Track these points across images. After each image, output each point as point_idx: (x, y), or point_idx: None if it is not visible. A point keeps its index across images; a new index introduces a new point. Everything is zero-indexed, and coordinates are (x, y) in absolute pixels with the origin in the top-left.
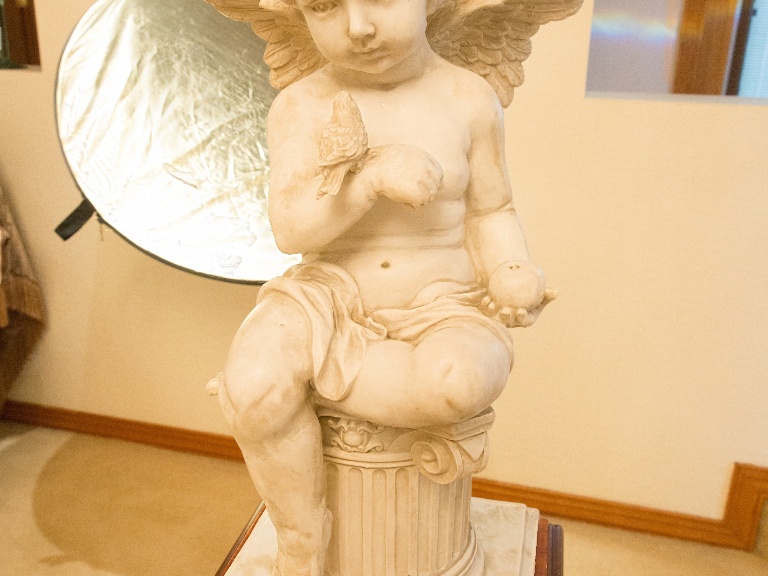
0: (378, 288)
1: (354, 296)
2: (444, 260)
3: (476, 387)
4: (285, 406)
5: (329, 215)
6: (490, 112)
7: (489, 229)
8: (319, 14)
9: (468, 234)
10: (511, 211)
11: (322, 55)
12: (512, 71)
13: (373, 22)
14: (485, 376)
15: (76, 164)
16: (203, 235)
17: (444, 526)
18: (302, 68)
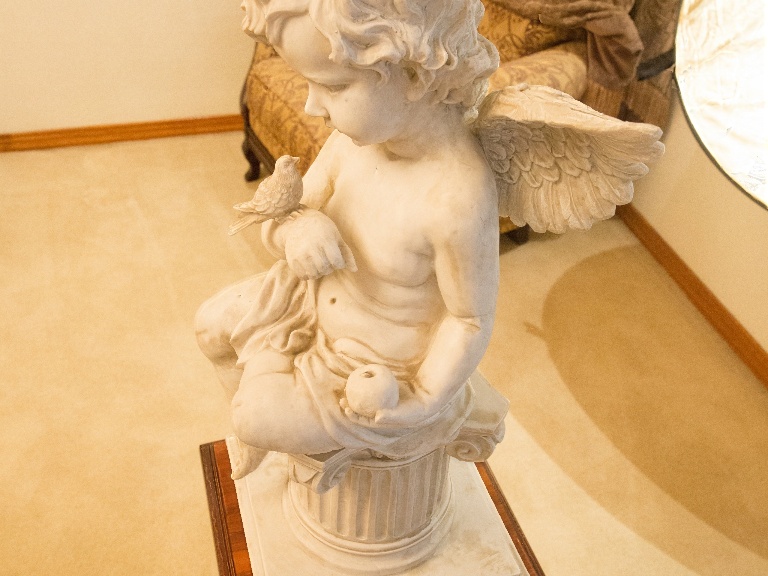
0: (322, 314)
1: (312, 307)
2: (369, 328)
3: (244, 430)
4: (211, 347)
5: (267, 242)
6: (446, 228)
7: (442, 328)
8: None
9: (442, 319)
10: (472, 326)
11: None
12: (607, 185)
13: (325, 107)
14: (256, 429)
15: (688, 8)
16: (761, 132)
17: (347, 510)
18: None
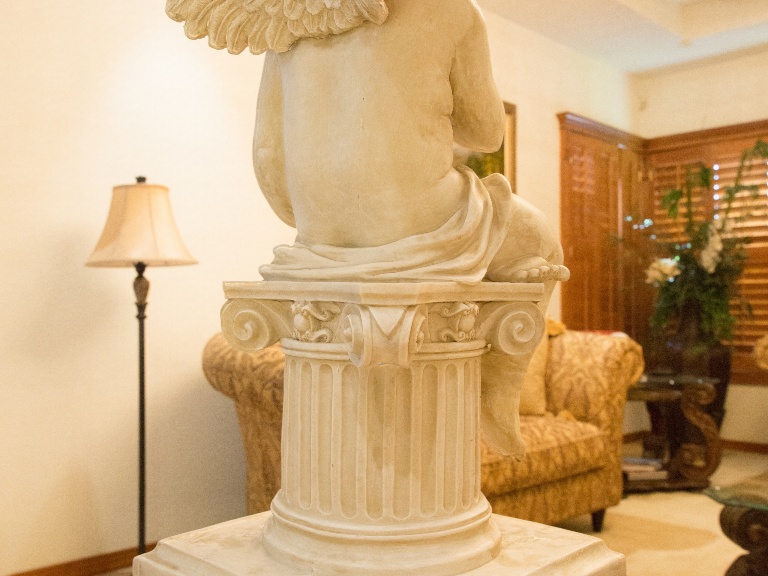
0: None
1: None
2: None
3: None
4: None
5: None
6: None
7: None
8: None
9: None
10: None
11: None
12: None
13: None
14: None
15: None
16: None
17: None
18: None
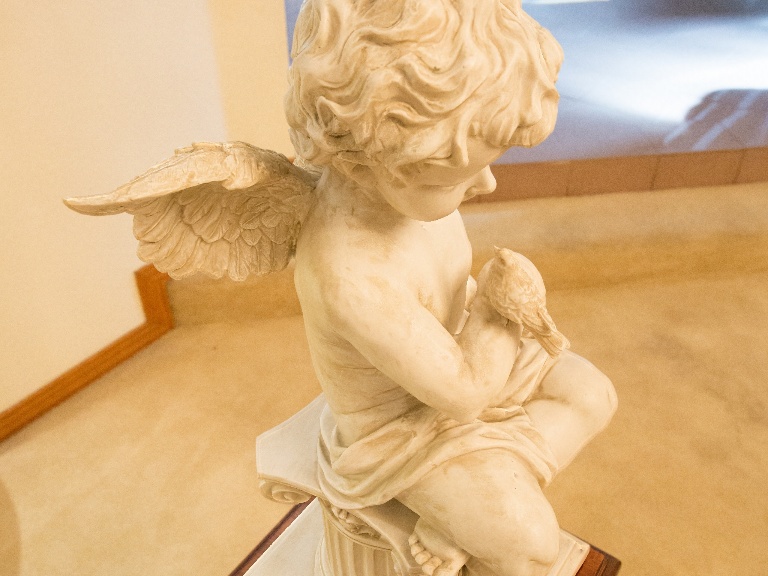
0: None
1: None
2: None
3: None
4: None
5: None
6: None
7: None
8: (450, 187)
9: None
10: None
11: (226, 195)
12: None
13: None
14: None
15: None
16: None
17: None
18: (194, 221)
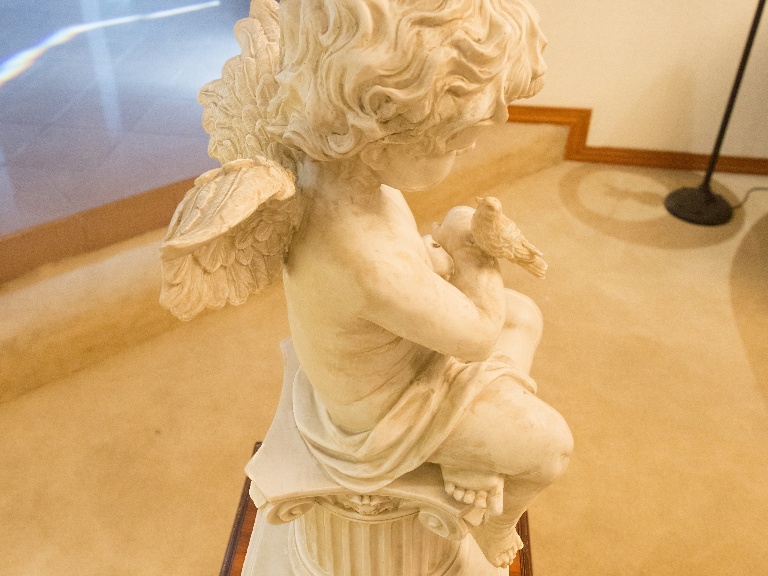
0: None
1: None
2: None
3: None
4: None
5: None
6: None
7: None
8: None
9: None
10: None
11: None
12: None
13: None
14: None
15: None
16: None
17: None
18: None
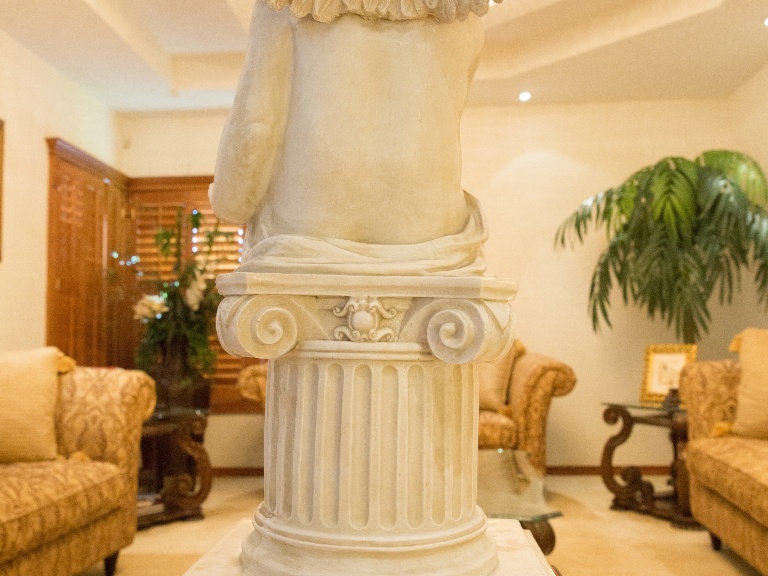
0: None
1: None
2: None
3: None
4: None
5: None
6: None
7: None
8: None
9: (282, 142)
10: None
11: None
12: None
13: None
14: None
15: None
16: None
17: None
18: None
